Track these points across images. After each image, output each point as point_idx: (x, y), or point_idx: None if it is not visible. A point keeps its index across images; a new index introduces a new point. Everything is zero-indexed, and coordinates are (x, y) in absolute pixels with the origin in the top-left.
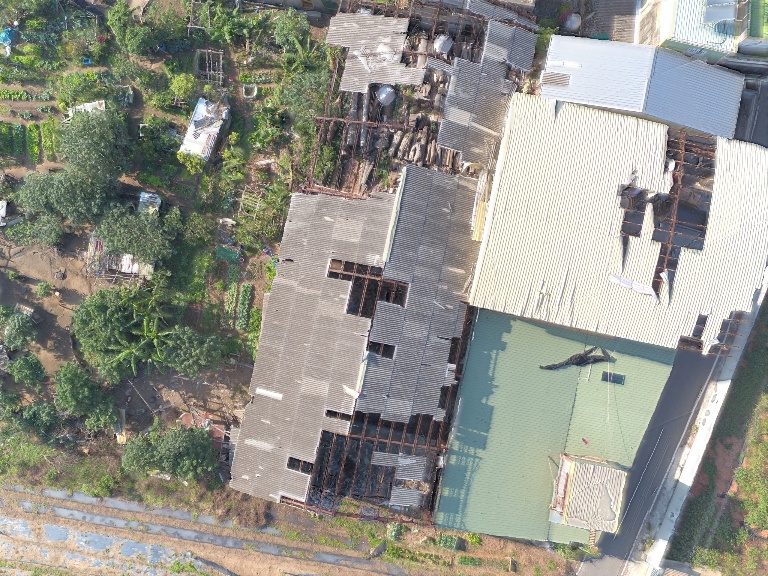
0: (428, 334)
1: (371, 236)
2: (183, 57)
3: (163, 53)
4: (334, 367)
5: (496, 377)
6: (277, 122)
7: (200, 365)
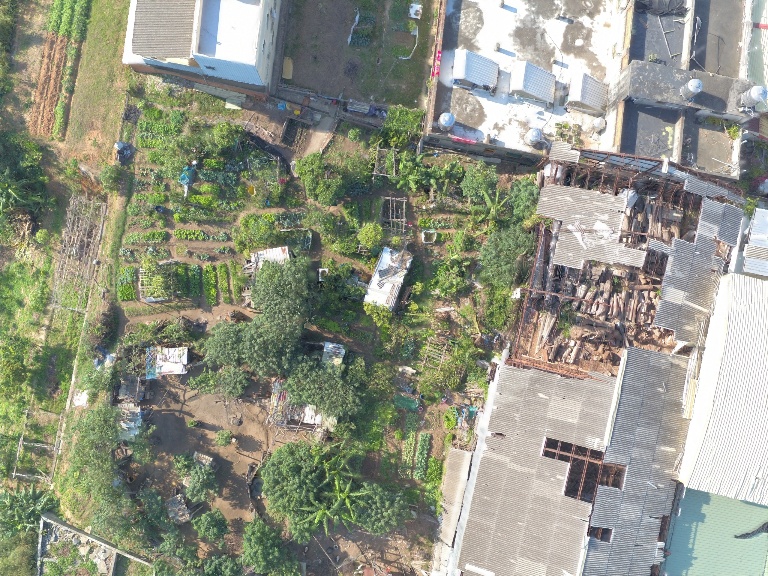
0: (642, 515)
1: (591, 418)
2: (361, 200)
3: (342, 196)
4: (553, 550)
5: (695, 549)
6: (459, 271)
7: (391, 525)
